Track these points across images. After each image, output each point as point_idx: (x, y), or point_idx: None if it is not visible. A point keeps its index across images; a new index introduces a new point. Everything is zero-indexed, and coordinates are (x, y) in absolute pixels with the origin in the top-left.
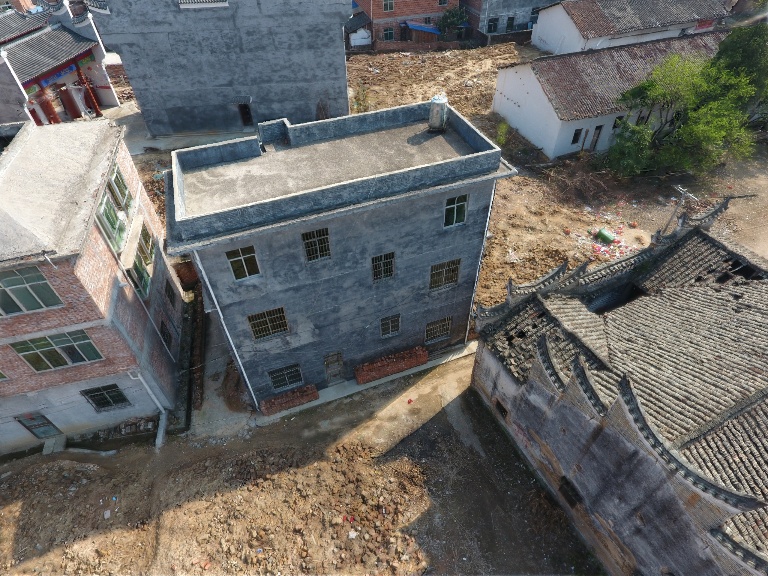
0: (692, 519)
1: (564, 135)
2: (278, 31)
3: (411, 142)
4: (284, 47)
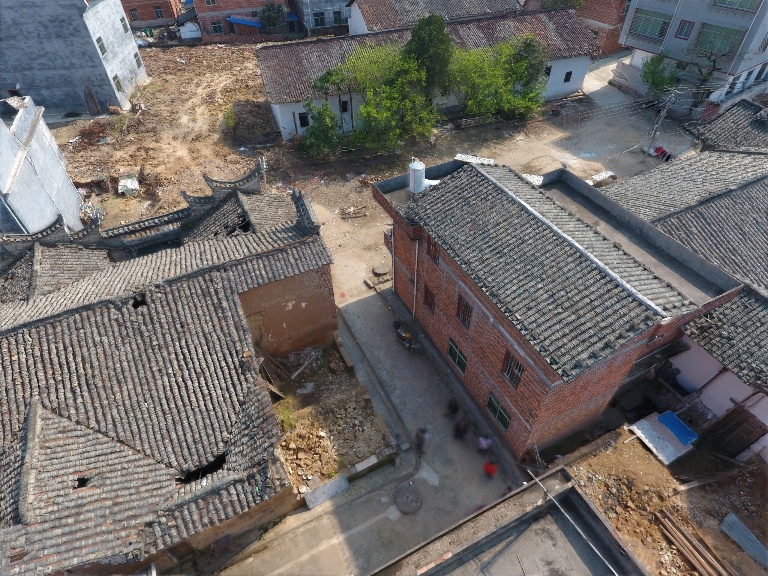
0: None
1: (288, 118)
2: (23, 21)
3: None
4: (34, 36)
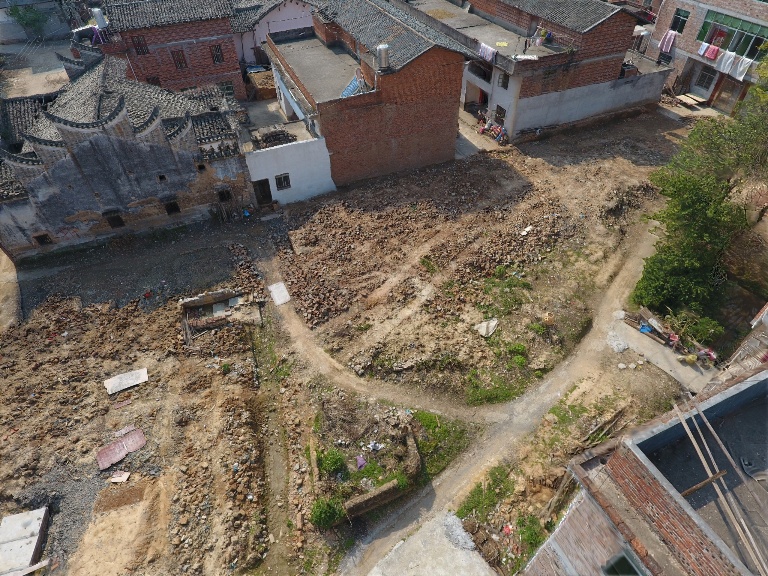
0: (129, 139)
1: None
2: None
3: None
4: None
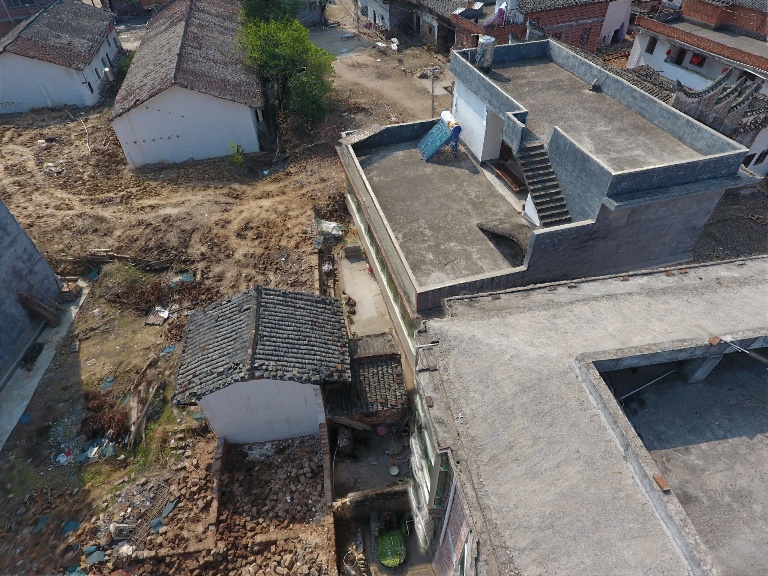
0: None
1: None
2: None
3: (507, 80)
4: None
